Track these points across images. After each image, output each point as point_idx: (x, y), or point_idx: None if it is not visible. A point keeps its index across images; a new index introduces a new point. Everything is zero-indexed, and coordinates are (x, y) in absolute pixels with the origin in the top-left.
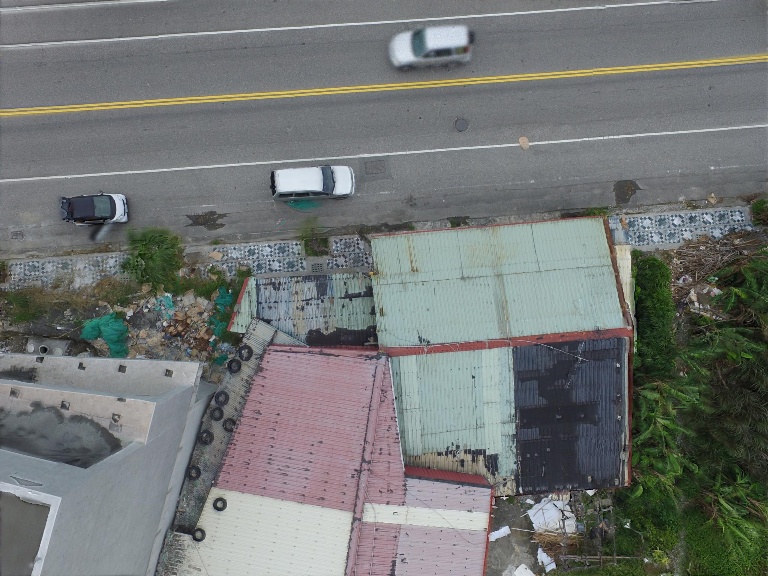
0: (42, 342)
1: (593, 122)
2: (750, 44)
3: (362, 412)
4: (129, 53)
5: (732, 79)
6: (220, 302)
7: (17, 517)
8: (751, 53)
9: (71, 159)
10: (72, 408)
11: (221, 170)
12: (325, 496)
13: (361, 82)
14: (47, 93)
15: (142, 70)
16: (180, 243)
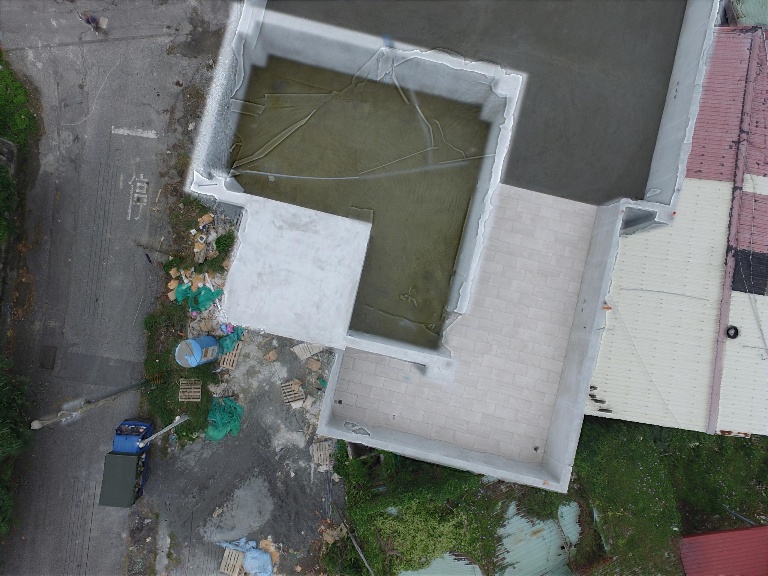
0: None
1: None
2: None
3: (738, 85)
4: None
5: None
6: None
7: None
8: None
9: None
10: None
11: None
12: (702, 169)
13: None
14: None
15: None
16: None
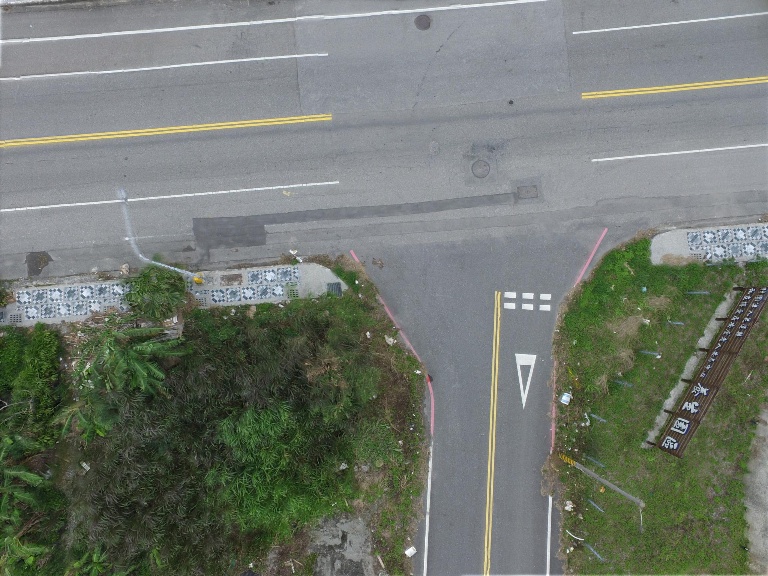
0: None
1: (4, 194)
2: (168, 114)
3: None
4: None
5: (149, 149)
6: None
7: None
8: (168, 123)
9: None
10: None
11: None
12: None
13: None
14: None
15: None
16: None
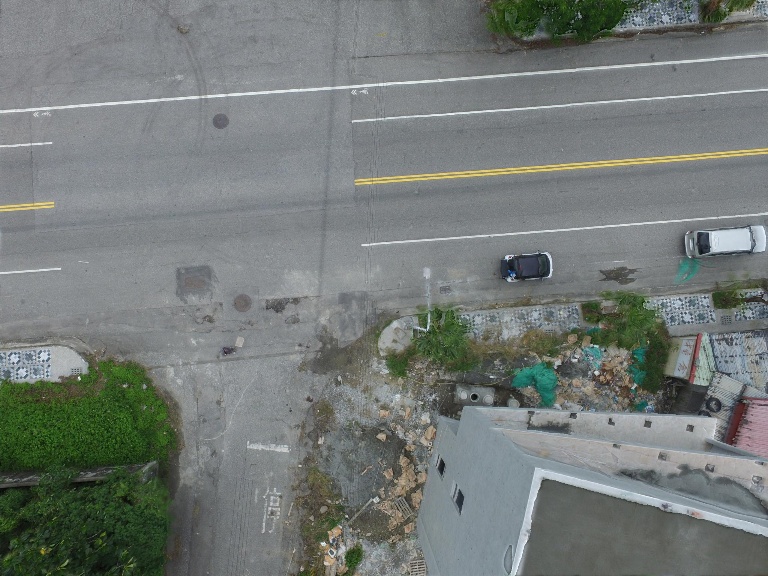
0: (470, 389)
1: None
2: None
3: None
4: (544, 120)
5: None
6: (640, 352)
7: None
8: None
9: (494, 219)
10: (716, 470)
11: (632, 228)
12: None
13: (758, 145)
14: (472, 158)
15: (556, 136)
16: (594, 296)
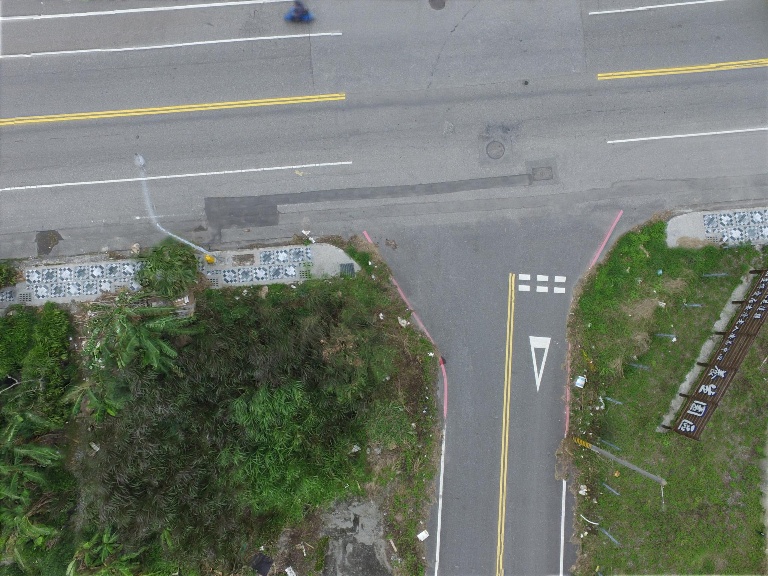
0: None
1: (14, 171)
2: (180, 93)
3: None
4: None
5: (161, 128)
6: None
7: None
8: (180, 102)
9: None
10: None
11: None
12: None
13: None
14: None
15: None
16: None
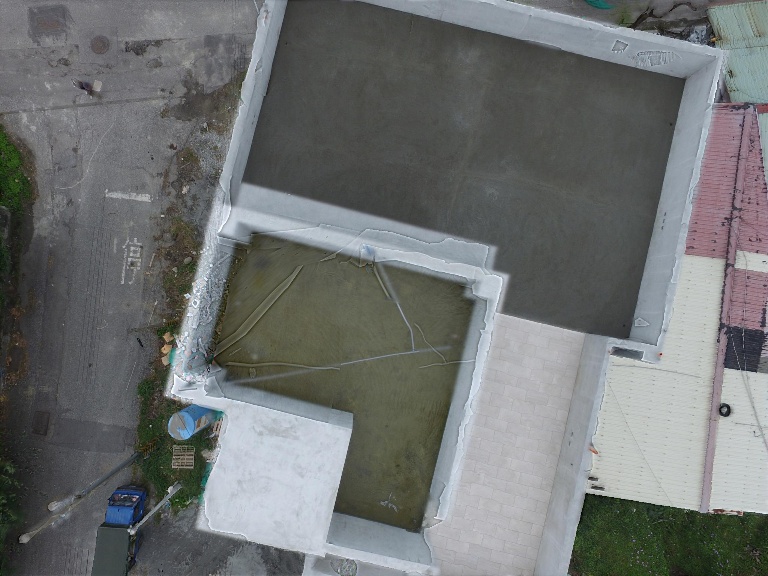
0: None
1: None
2: None
3: (730, 162)
4: None
5: None
6: None
7: (628, 106)
8: None
9: None
10: None
11: None
12: (695, 245)
13: None
14: None
15: None
16: None
